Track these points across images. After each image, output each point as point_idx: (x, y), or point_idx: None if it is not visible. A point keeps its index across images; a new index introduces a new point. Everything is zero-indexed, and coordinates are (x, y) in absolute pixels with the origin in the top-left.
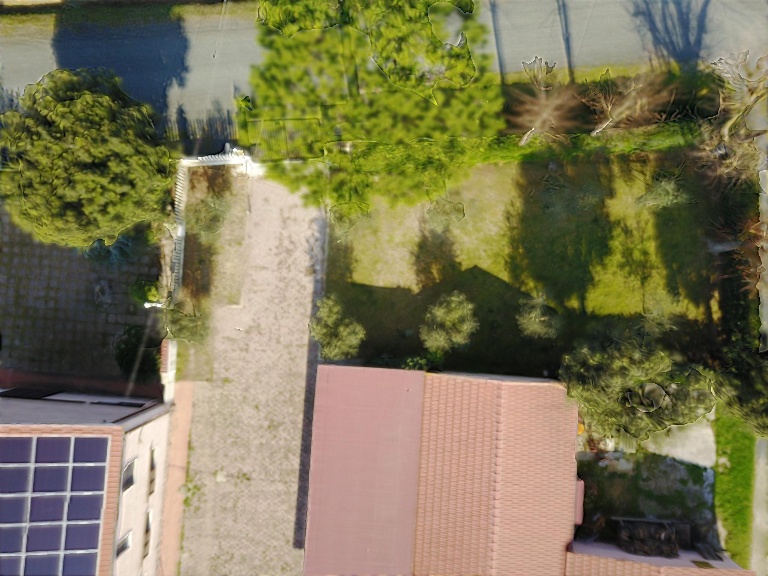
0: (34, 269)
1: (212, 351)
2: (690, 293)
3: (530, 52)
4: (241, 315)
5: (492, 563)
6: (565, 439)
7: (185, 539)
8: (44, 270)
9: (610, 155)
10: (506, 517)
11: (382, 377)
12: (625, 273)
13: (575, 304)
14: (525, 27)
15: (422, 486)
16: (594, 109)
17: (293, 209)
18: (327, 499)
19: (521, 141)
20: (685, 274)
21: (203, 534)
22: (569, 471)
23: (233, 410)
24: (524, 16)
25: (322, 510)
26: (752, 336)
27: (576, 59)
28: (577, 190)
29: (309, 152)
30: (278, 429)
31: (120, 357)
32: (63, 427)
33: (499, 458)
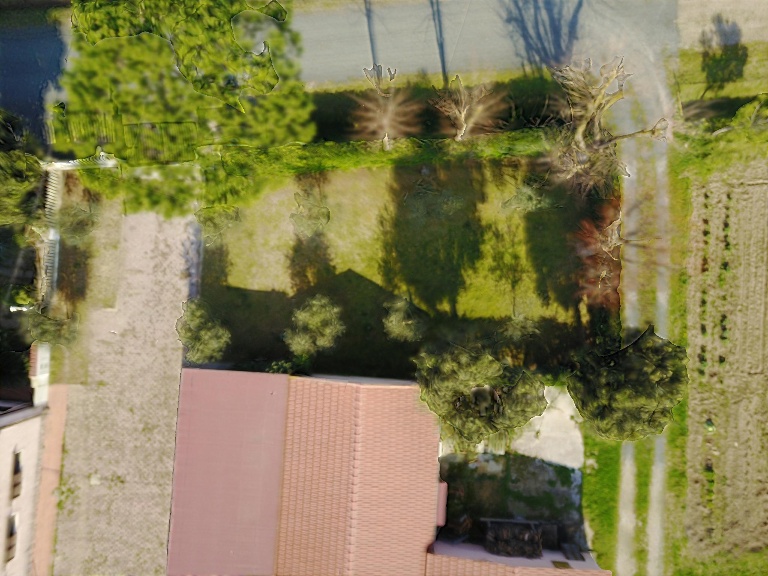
0: None
1: (86, 354)
2: (559, 296)
3: (405, 57)
4: (116, 318)
5: (349, 565)
6: (427, 441)
7: (59, 542)
8: None
9: (482, 160)
10: (364, 519)
11: (246, 380)
12: (496, 277)
13: (447, 307)
14: (400, 32)
15: (286, 488)
16: (448, 115)
17: (169, 212)
18: (191, 502)
19: (384, 146)
20: (554, 278)
21: (77, 537)
22: (431, 473)
23: (107, 413)
24: (399, 21)
25: (185, 513)
26: (612, 339)
27: (450, 64)
28: (439, 195)
29: (185, 155)
30: (152, 432)
31: None
32: None
33: (357, 461)
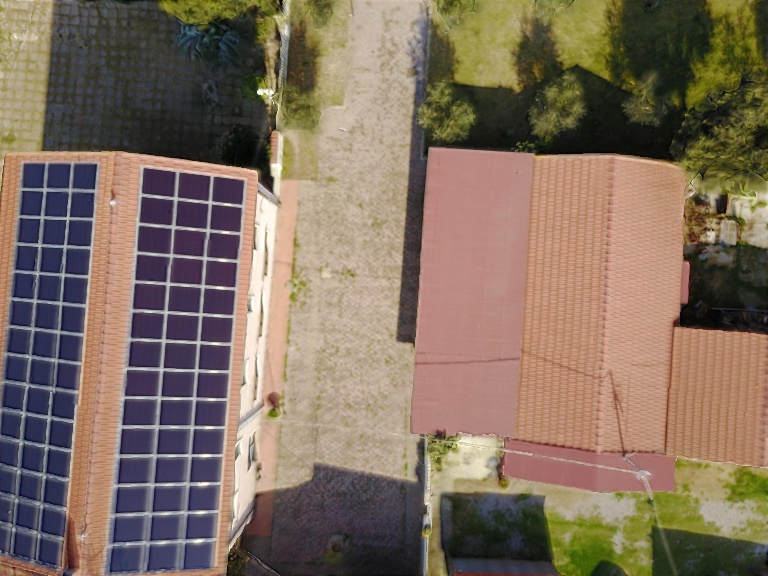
0: (141, 72)
1: (316, 151)
2: None
3: None
4: (344, 116)
5: (604, 331)
6: (672, 219)
7: (291, 333)
8: (151, 73)
9: None
10: (617, 288)
11: (492, 159)
12: (726, 70)
13: (676, 101)
14: None
15: (531, 266)
16: None
17: (395, 12)
18: (438, 278)
19: None
20: None
21: (309, 328)
22: (676, 250)
23: (337, 208)
24: None
25: (433, 288)
26: None
27: None
28: None
29: None
30: (381, 227)
31: (228, 154)
32: (203, 165)
33: (611, 230)
